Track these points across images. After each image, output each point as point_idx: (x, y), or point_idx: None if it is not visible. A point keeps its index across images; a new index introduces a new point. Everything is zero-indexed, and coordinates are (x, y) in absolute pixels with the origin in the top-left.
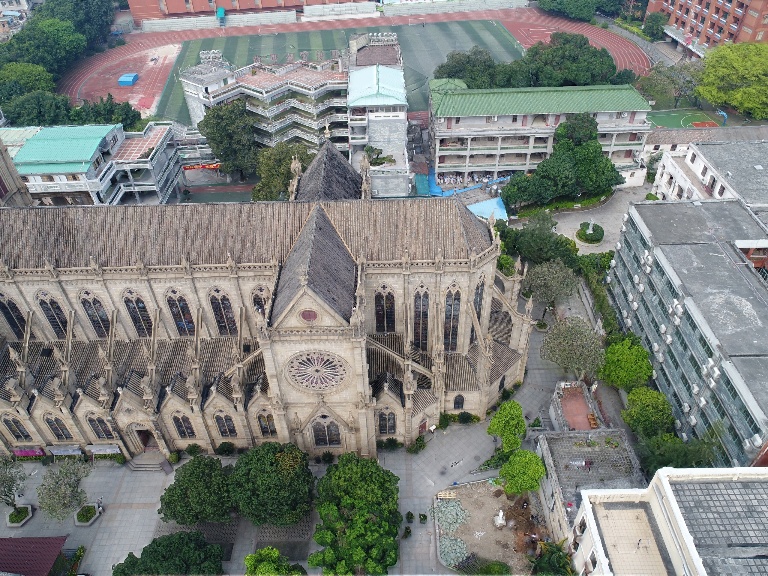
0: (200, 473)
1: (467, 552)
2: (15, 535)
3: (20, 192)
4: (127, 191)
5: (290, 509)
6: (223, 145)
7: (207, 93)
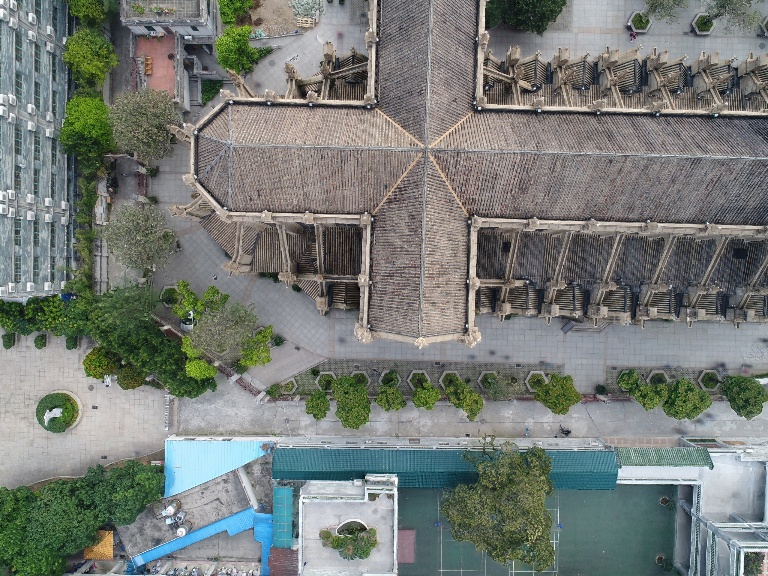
0: None
1: None
2: (700, 7)
3: None
4: (760, 523)
5: None
6: None
7: None
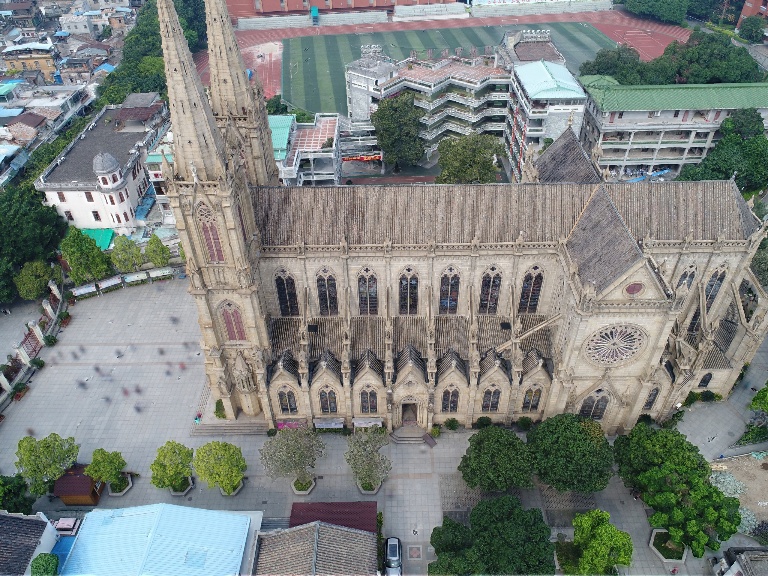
0: (505, 441)
1: (757, 520)
2: None
3: (273, 174)
4: (306, 180)
5: (598, 476)
6: (395, 136)
7: (377, 86)
